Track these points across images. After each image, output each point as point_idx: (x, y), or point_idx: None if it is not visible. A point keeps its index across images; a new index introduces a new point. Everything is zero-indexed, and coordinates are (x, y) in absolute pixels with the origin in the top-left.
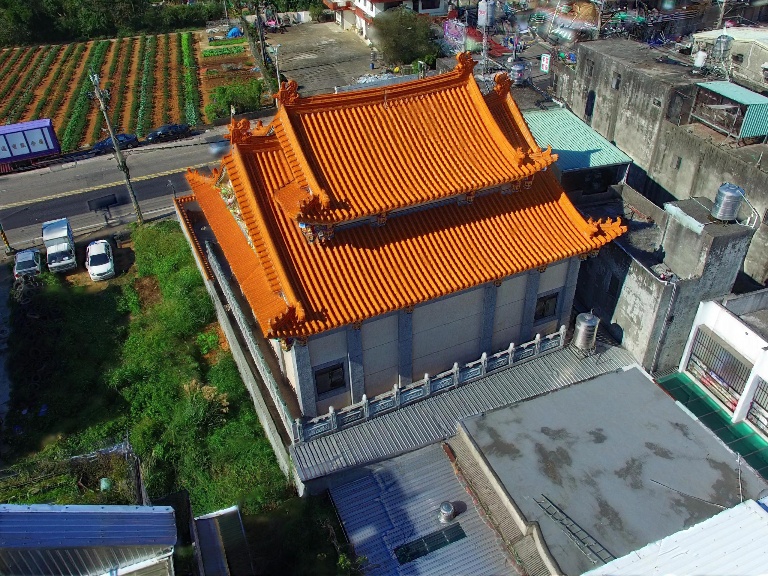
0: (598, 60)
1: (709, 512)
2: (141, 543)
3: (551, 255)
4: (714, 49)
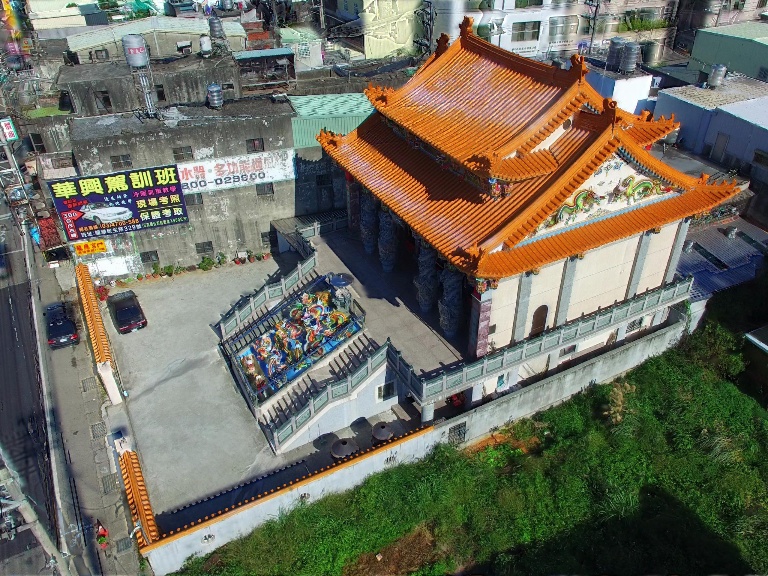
0: (115, 86)
1: None
2: None
3: None
4: (217, 30)
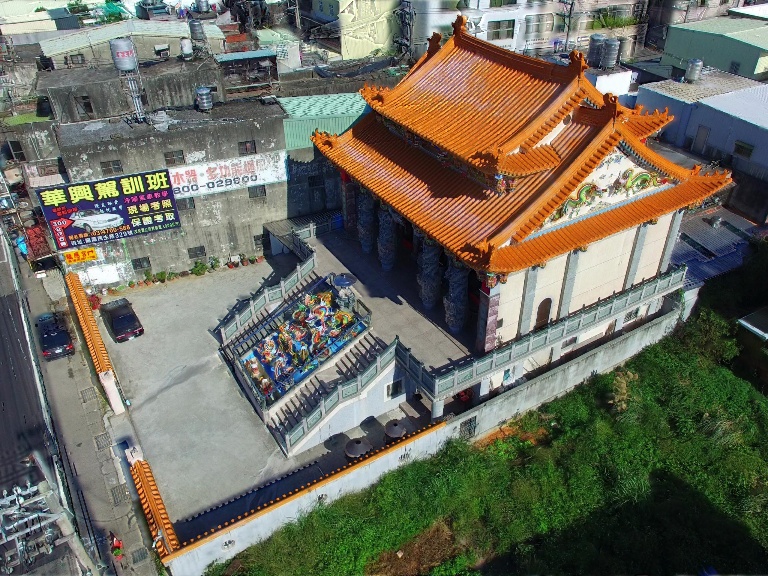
0: (97, 90)
1: (653, 146)
2: None
3: None
4: (198, 33)
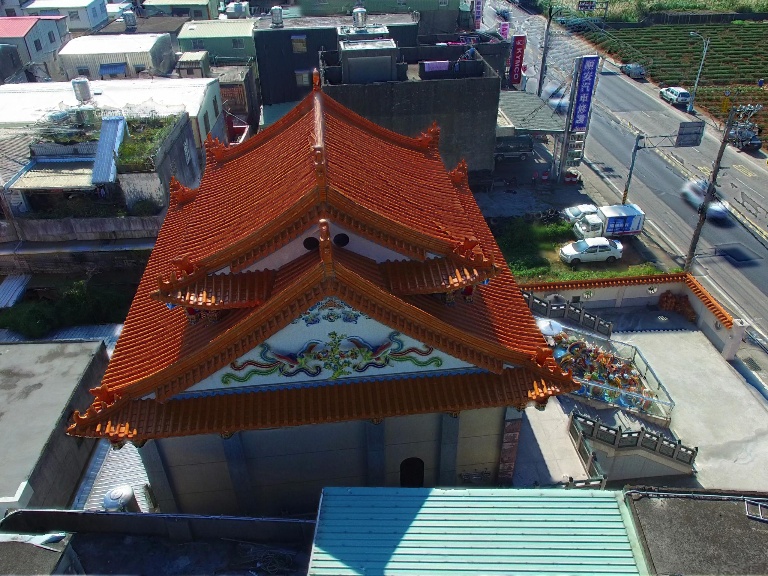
0: None
1: None
2: (94, 168)
3: (117, 356)
4: None
